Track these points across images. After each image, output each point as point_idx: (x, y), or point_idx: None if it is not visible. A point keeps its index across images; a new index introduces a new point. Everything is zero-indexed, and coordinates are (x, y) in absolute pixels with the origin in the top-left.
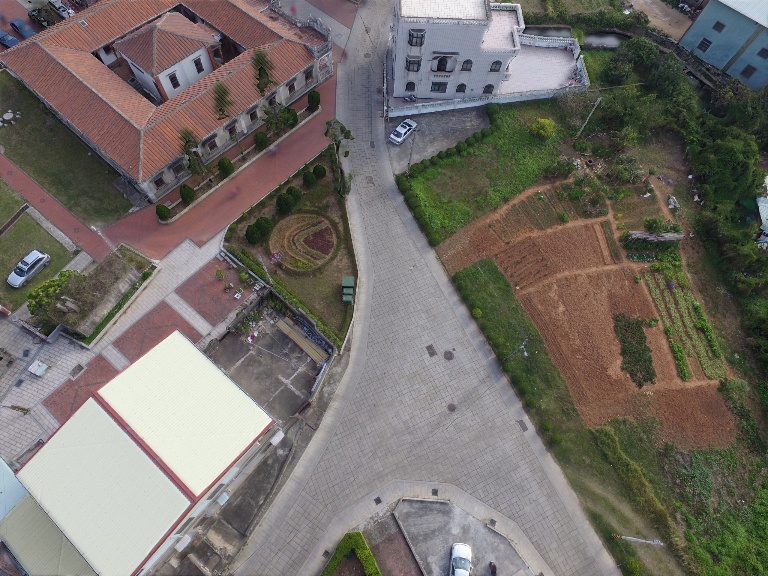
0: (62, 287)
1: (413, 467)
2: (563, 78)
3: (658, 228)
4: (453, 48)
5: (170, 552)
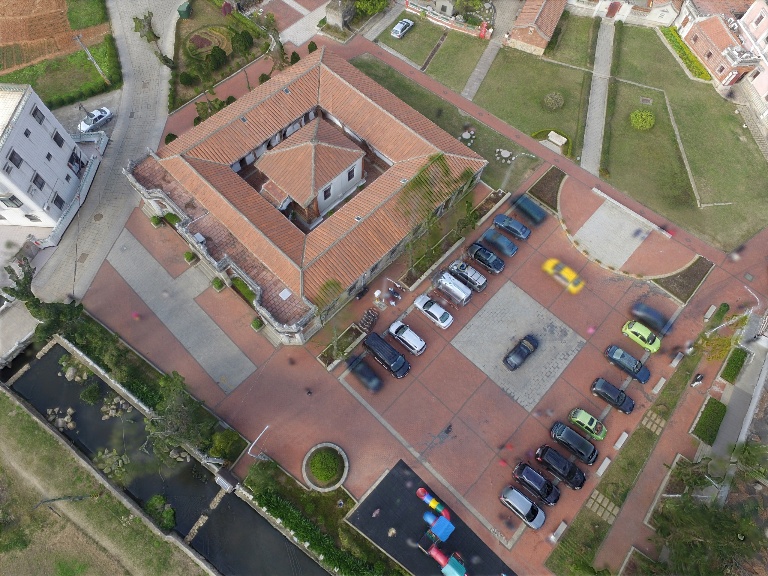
0: None
1: None
2: None
3: None
4: None
5: None
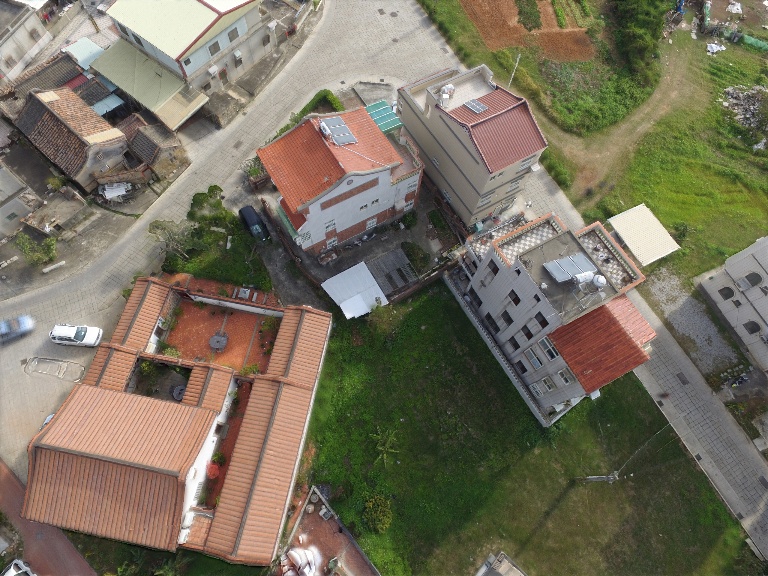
0: None
1: (367, 68)
2: None
3: None
4: None
5: (205, 81)
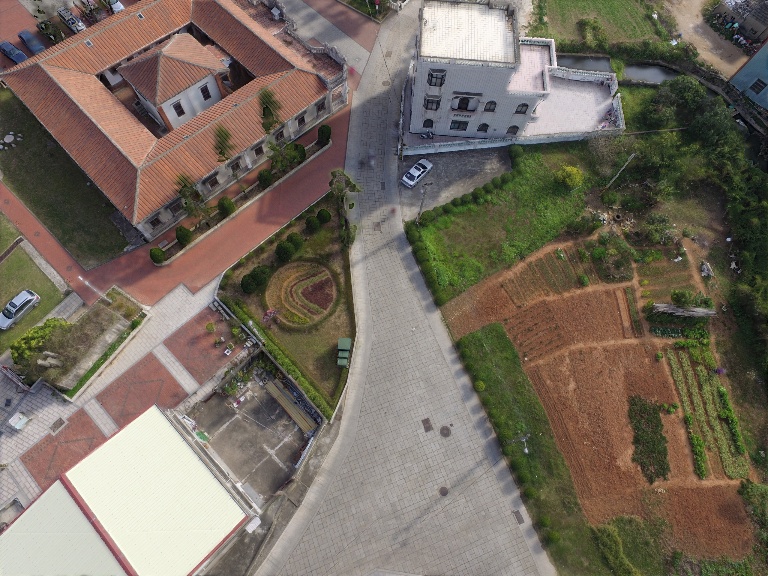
0: (46, 339)
1: (397, 556)
2: (596, 118)
3: (687, 303)
4: (476, 89)
5: None
